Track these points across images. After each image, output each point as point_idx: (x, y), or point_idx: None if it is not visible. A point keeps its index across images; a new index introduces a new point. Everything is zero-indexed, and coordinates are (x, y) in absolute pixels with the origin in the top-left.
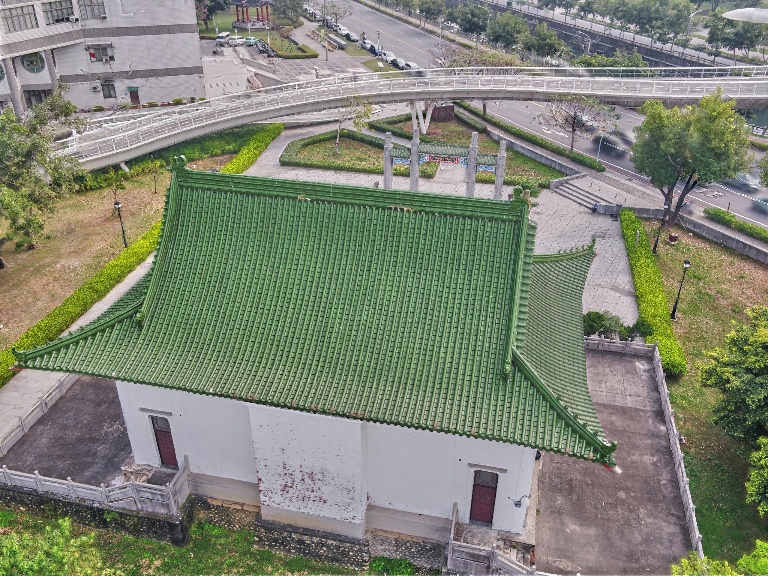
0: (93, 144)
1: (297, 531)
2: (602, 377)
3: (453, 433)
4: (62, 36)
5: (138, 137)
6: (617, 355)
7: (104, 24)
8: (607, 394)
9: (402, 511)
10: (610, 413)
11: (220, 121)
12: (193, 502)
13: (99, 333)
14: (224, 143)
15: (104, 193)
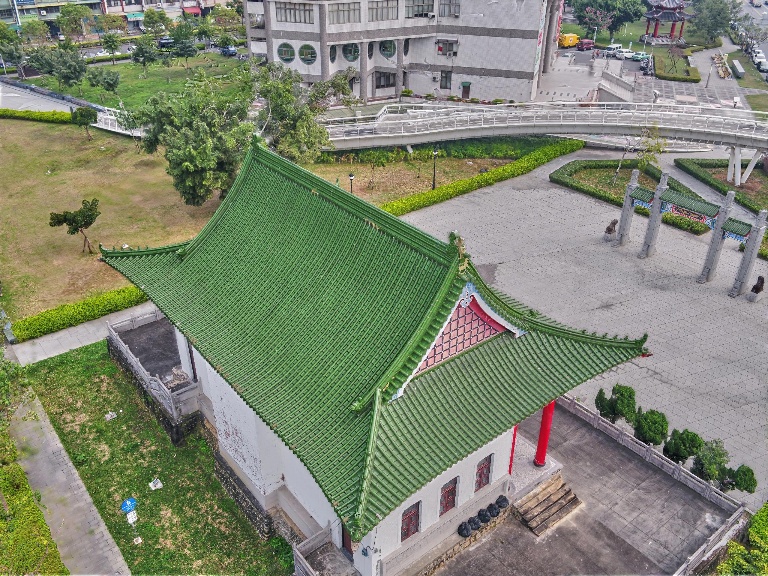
0: (391, 124)
1: (232, 476)
2: (643, 506)
3: (282, 439)
4: (417, 29)
5: (430, 126)
6: (691, 494)
7: (456, 22)
8: (628, 525)
9: (302, 505)
10: (608, 544)
11: (509, 126)
12: (197, 417)
13: (158, 255)
14: (511, 148)
15: (380, 167)
